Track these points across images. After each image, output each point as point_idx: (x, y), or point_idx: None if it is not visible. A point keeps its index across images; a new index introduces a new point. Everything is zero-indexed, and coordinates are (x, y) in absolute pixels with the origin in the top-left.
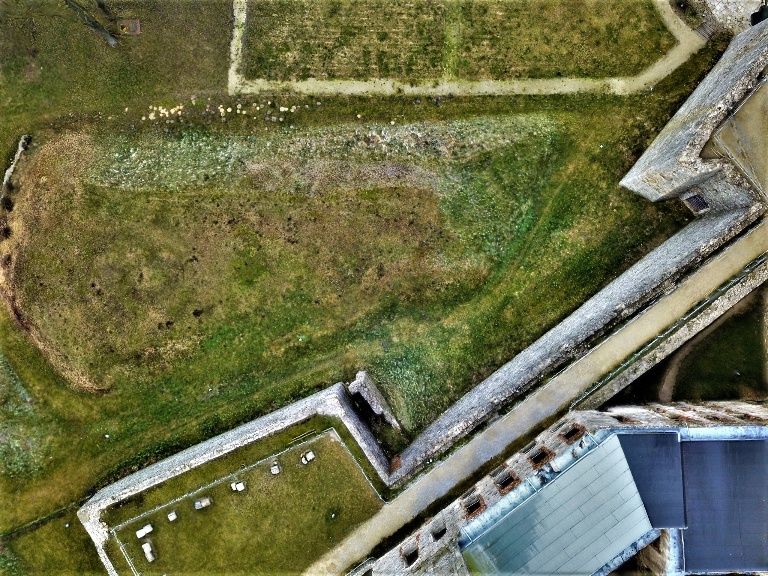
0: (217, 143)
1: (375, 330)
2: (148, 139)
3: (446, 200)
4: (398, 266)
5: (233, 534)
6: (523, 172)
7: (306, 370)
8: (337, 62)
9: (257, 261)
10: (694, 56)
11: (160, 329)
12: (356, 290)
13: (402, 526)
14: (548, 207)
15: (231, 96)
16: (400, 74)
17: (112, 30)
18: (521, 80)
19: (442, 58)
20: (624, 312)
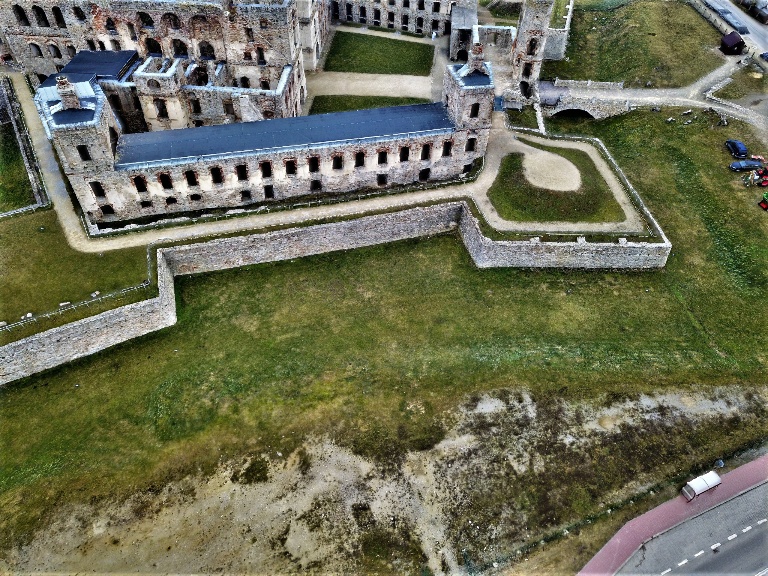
0: None
1: None
2: None
3: None
4: None
5: (19, 277)
6: None
7: None
8: None
9: None
10: None
11: None
12: None
13: (71, 202)
14: None
15: None
16: None
17: None
18: None
19: None
20: None
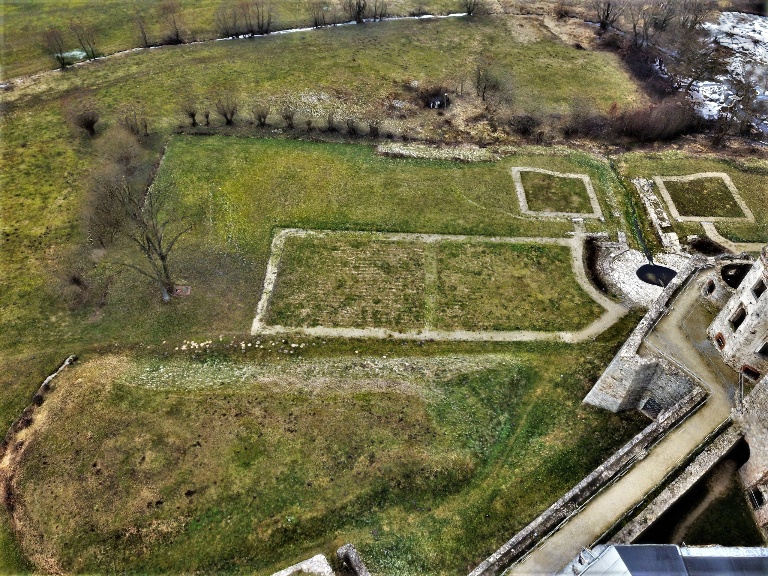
0: (235, 366)
1: (365, 517)
2: (177, 361)
3: (431, 405)
4: (389, 454)
5: None
6: (497, 390)
7: (291, 558)
8: (341, 316)
9: (257, 446)
10: (622, 319)
11: (148, 508)
12: (348, 475)
13: None
14: (524, 420)
15: (253, 336)
16: (391, 325)
17: (169, 290)
18: (488, 331)
19: (424, 316)
20: (604, 474)
